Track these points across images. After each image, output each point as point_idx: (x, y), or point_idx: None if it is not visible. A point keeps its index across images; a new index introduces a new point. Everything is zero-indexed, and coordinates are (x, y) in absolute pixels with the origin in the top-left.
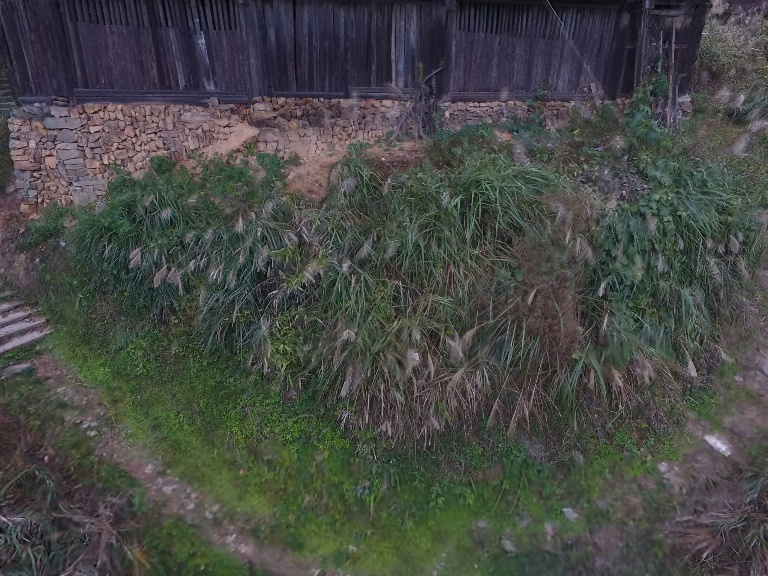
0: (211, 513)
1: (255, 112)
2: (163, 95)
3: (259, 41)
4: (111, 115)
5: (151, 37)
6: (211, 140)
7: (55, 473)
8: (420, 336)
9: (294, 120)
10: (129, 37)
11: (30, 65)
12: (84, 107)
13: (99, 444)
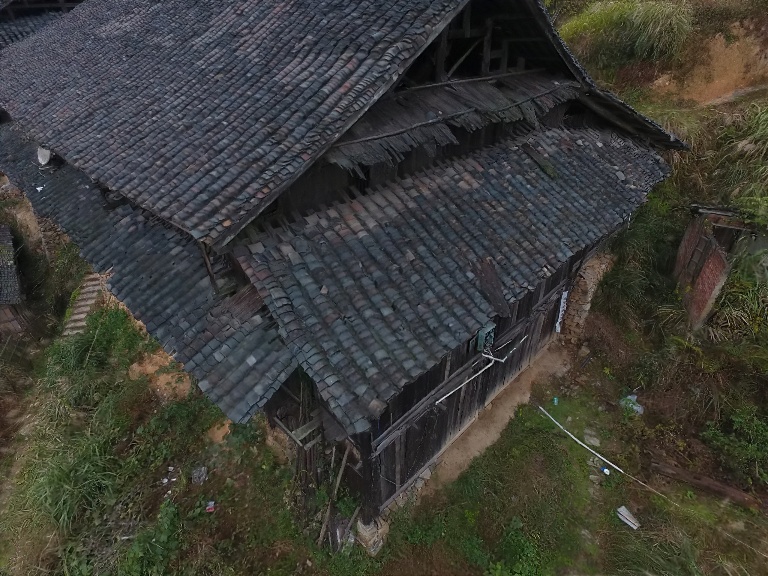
0: (3, 512)
1: None
2: None
3: None
4: None
5: None
6: None
7: (6, 447)
8: (2, 531)
9: None
10: None
11: None
12: None
13: (23, 446)
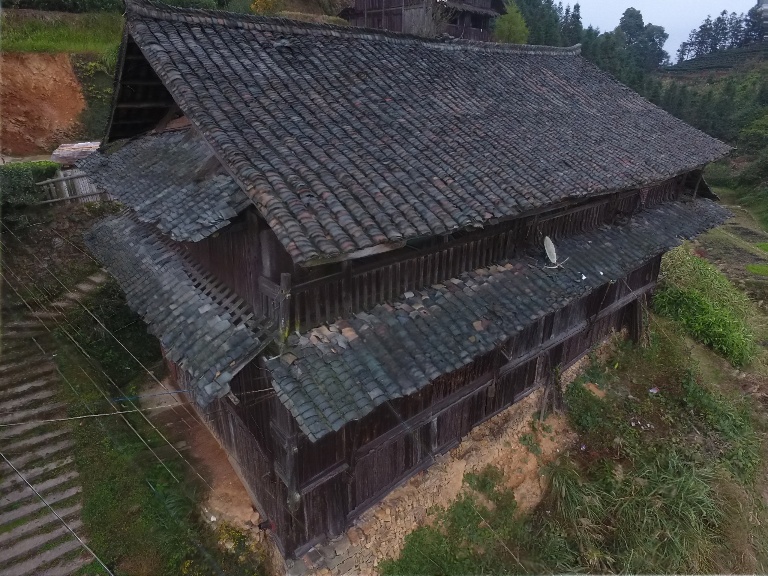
0: None
1: (463, 448)
2: (407, 475)
3: (471, 399)
4: (382, 523)
5: (404, 437)
6: (439, 489)
7: None
8: None
9: (484, 439)
10: (389, 447)
11: (308, 518)
12: (363, 531)
13: None
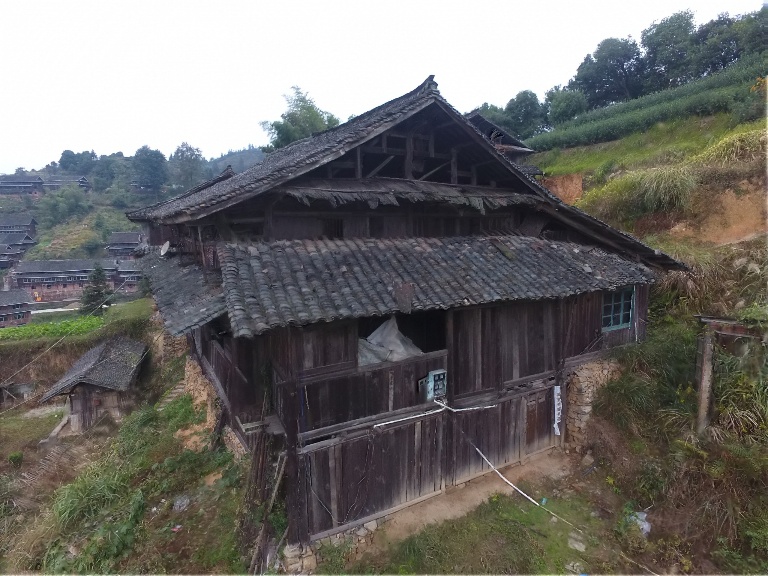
0: None
1: None
2: None
3: None
4: None
5: None
6: None
7: None
8: None
9: None
10: None
11: None
12: None
13: None
